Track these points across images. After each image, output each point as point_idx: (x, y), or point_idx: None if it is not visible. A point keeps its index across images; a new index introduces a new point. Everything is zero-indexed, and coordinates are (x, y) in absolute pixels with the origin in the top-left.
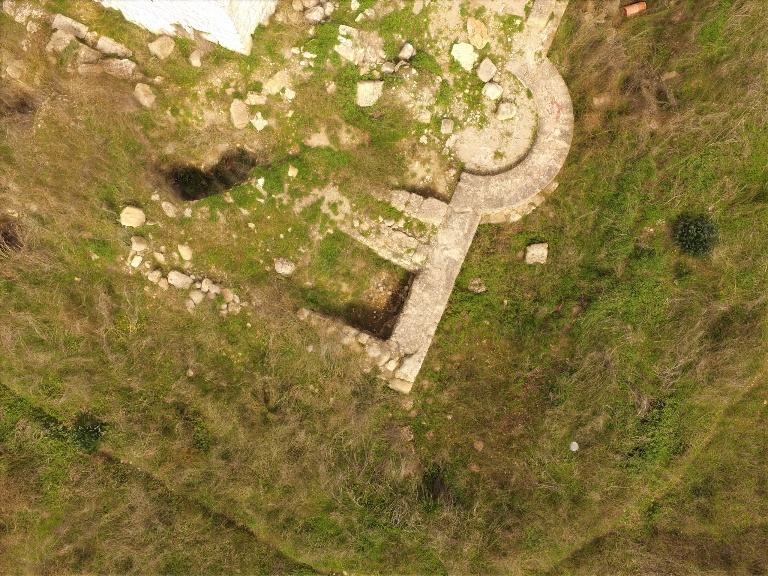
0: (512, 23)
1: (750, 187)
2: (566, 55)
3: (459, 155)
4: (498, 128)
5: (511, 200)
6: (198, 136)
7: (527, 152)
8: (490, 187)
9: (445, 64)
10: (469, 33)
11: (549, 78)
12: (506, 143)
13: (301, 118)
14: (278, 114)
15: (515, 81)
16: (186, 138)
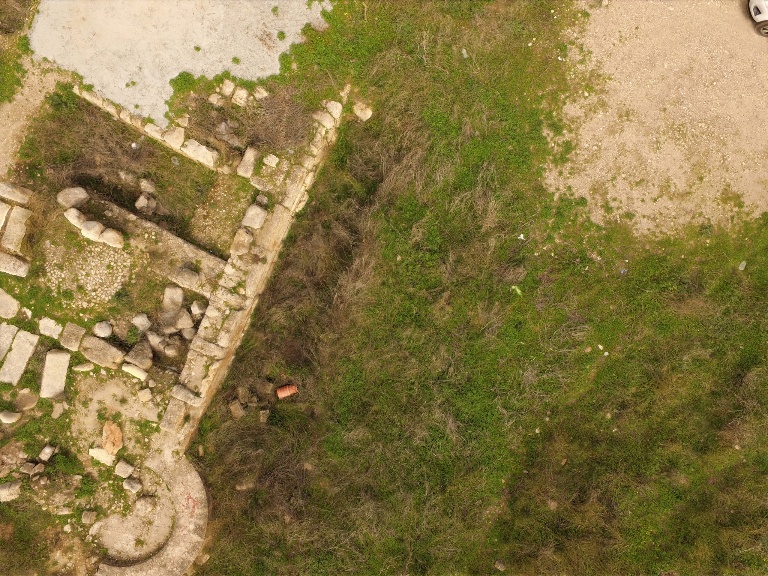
0: (149, 426)
1: None
2: None
3: (103, 541)
4: (140, 516)
5: None
6: None
7: (166, 541)
8: None
9: (86, 461)
10: (103, 439)
11: (186, 474)
12: (147, 531)
13: None
14: None
15: (156, 474)
16: None
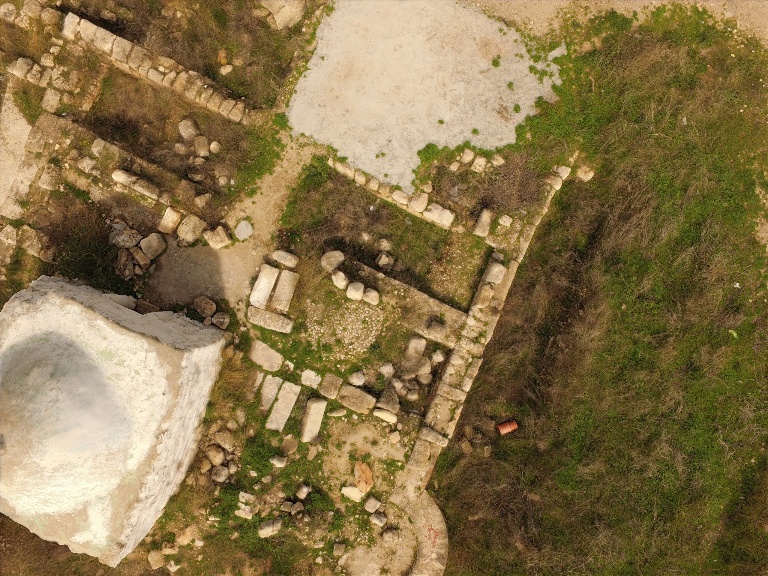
0: (394, 464)
1: None
2: (445, 478)
3: (350, 571)
4: (384, 547)
5: None
6: (122, 572)
7: (409, 569)
8: None
9: (337, 498)
10: (356, 478)
11: (427, 508)
12: (391, 561)
13: (209, 562)
14: (189, 560)
15: (398, 508)
16: (113, 568)
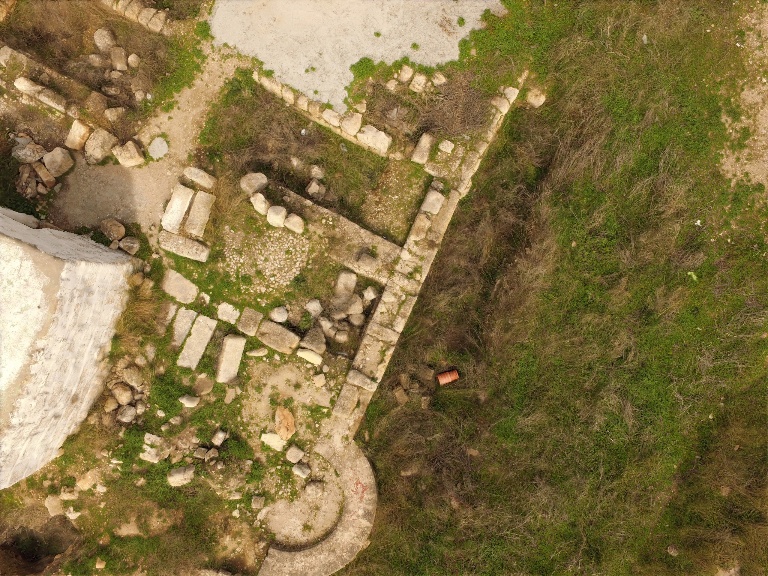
0: (320, 411)
1: (537, 575)
2: None
3: (270, 526)
4: (307, 502)
5: (315, 575)
6: (18, 519)
7: (334, 526)
8: (295, 563)
9: (257, 446)
10: (276, 424)
11: (355, 460)
12: (314, 516)
13: (112, 510)
14: (90, 506)
15: (324, 460)
16: (10, 514)
